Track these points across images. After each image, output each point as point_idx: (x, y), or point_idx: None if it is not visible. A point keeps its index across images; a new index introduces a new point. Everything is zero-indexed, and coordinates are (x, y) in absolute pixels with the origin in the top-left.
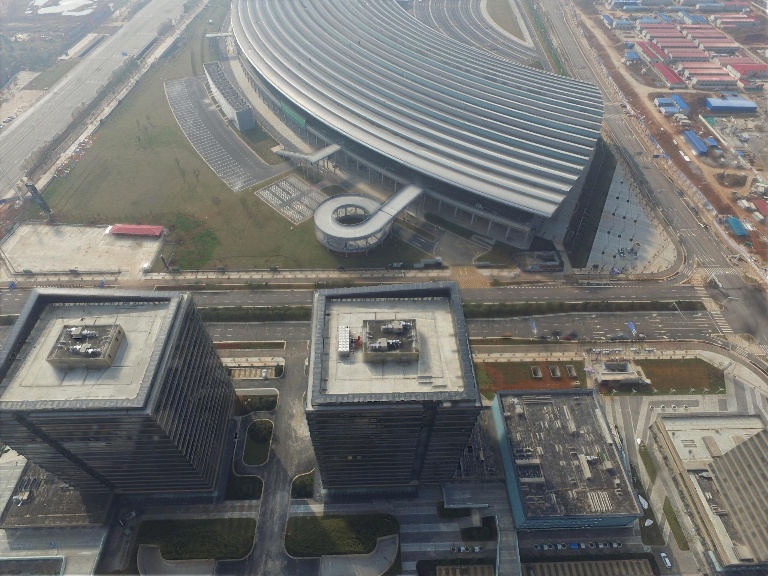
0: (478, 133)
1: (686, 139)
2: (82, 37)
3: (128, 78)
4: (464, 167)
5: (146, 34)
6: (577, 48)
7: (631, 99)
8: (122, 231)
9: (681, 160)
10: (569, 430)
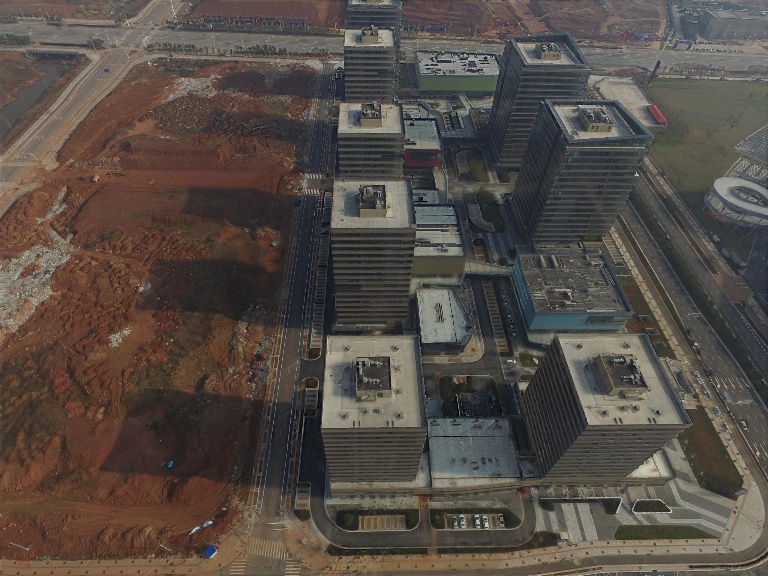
0: None
1: None
2: None
3: None
4: None
5: None
6: None
7: None
8: (651, 108)
9: None
10: None
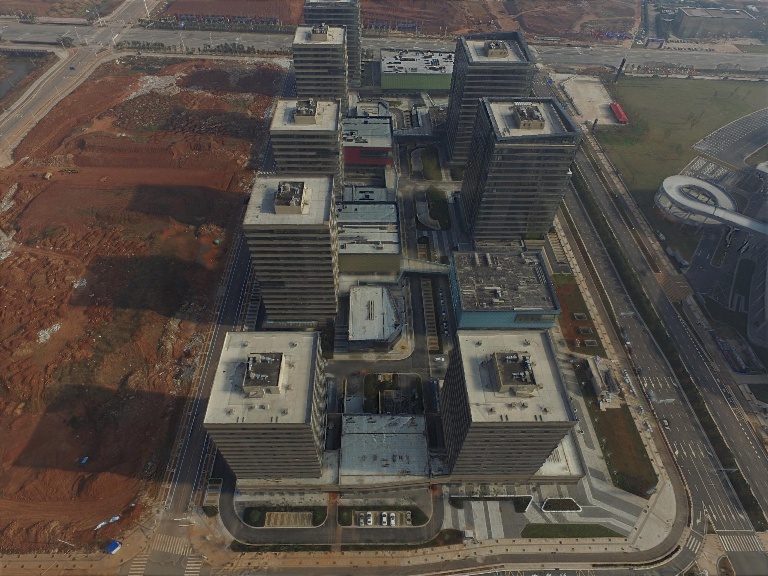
0: None
1: None
2: None
3: None
4: None
5: None
6: None
7: None
8: (613, 107)
9: None
10: None
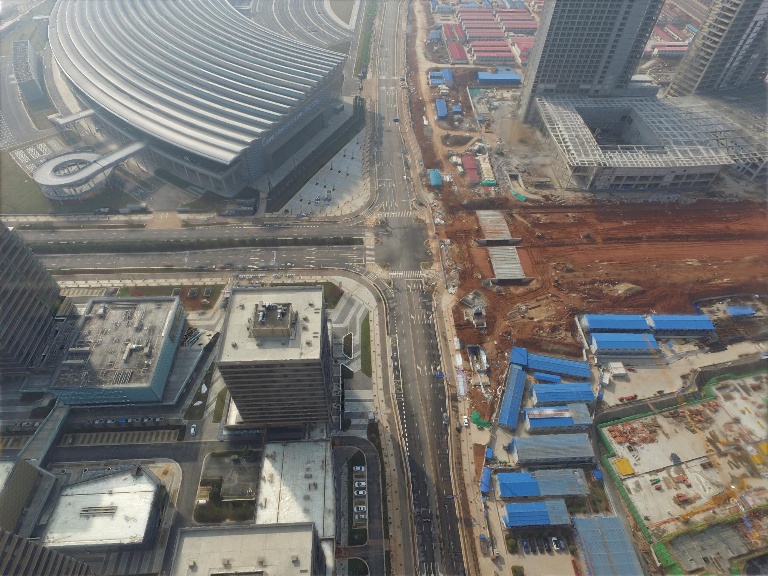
0: (203, 96)
1: None
2: None
3: None
4: (174, 124)
5: None
6: (394, 30)
7: (413, 73)
8: None
9: (420, 124)
10: None
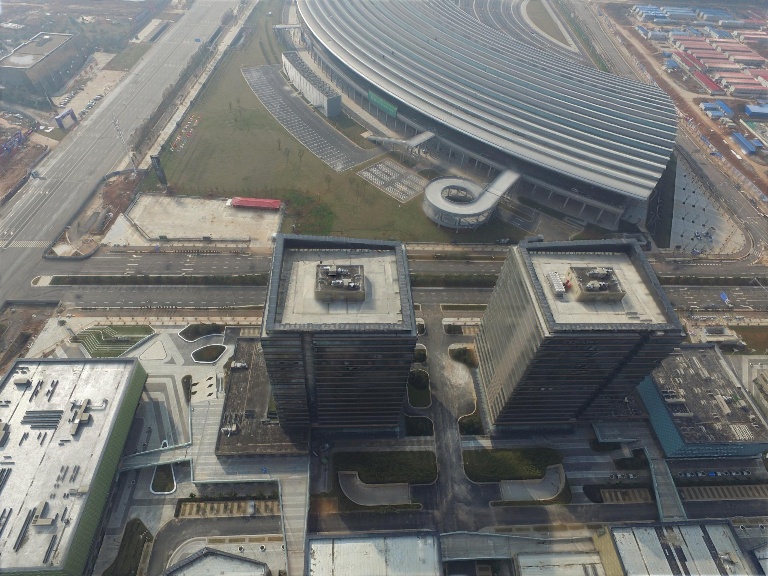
0: (567, 125)
1: (735, 140)
2: (148, 22)
3: (205, 63)
4: (561, 154)
5: (210, 22)
6: (619, 55)
7: (677, 103)
8: (244, 203)
9: (734, 158)
10: (702, 376)
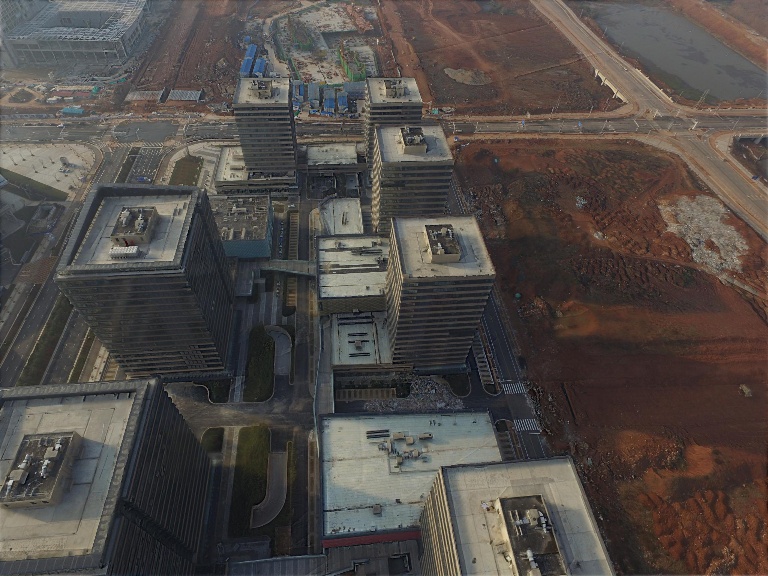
0: None
1: None
2: None
3: None
4: None
5: None
6: None
7: None
8: None
9: None
10: (214, 213)
